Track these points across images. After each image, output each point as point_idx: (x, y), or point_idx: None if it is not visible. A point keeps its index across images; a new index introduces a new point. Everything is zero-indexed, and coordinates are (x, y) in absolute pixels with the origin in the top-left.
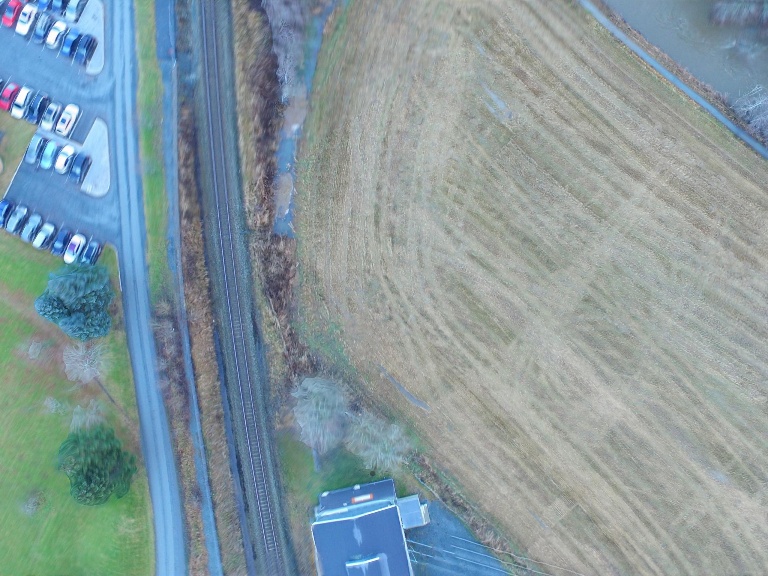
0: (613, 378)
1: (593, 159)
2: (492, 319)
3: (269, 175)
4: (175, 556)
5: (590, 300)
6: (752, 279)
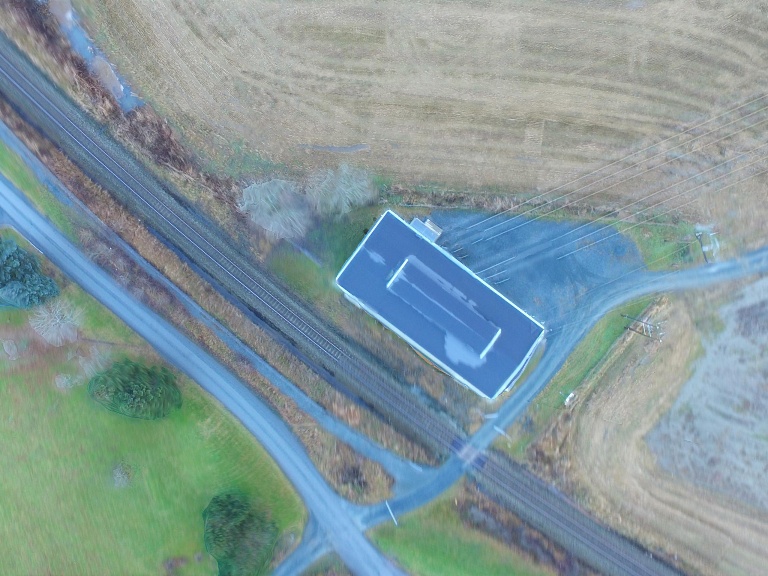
0: None
1: None
2: (355, 34)
3: (80, 68)
4: (267, 420)
5: None
6: None
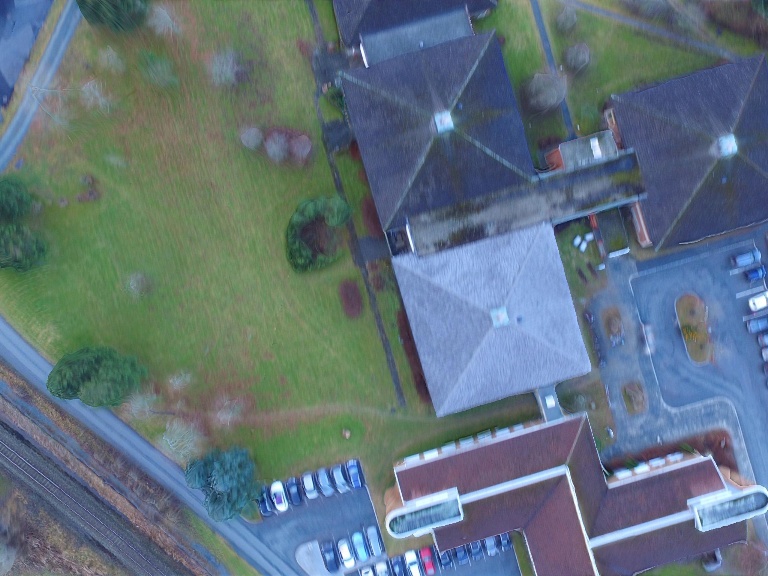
0: None
1: None
2: None
3: None
4: None
5: None
6: None
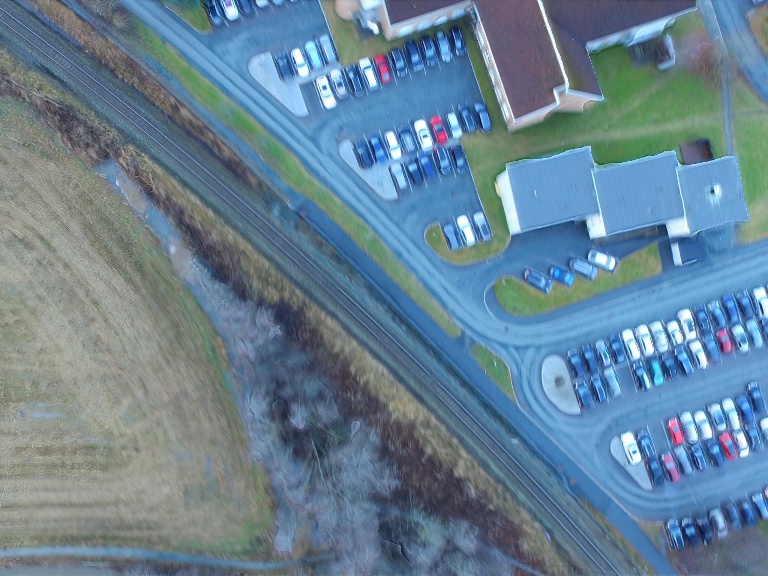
0: None
1: None
2: None
3: (152, 195)
4: None
5: None
6: None
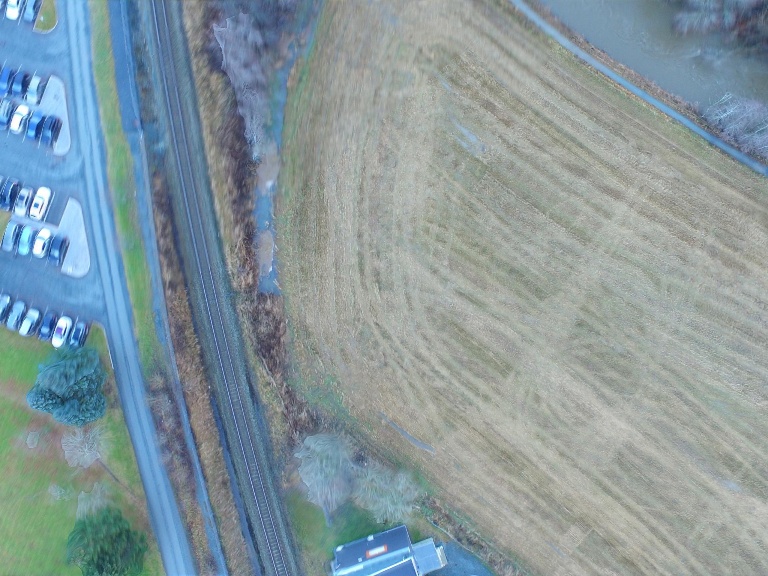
0: (614, 399)
1: (571, 183)
2: (487, 354)
3: (248, 235)
4: None
5: (583, 324)
6: (742, 285)
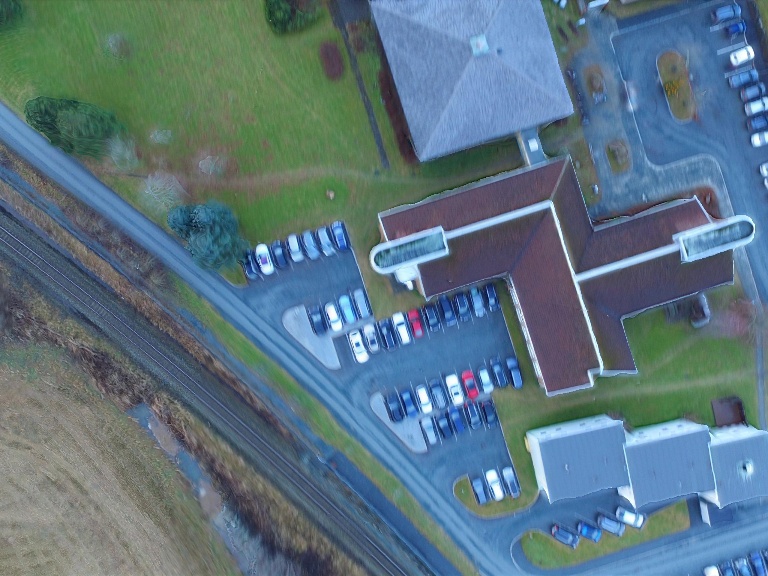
0: None
1: None
2: None
3: (184, 442)
4: None
5: None
6: None
